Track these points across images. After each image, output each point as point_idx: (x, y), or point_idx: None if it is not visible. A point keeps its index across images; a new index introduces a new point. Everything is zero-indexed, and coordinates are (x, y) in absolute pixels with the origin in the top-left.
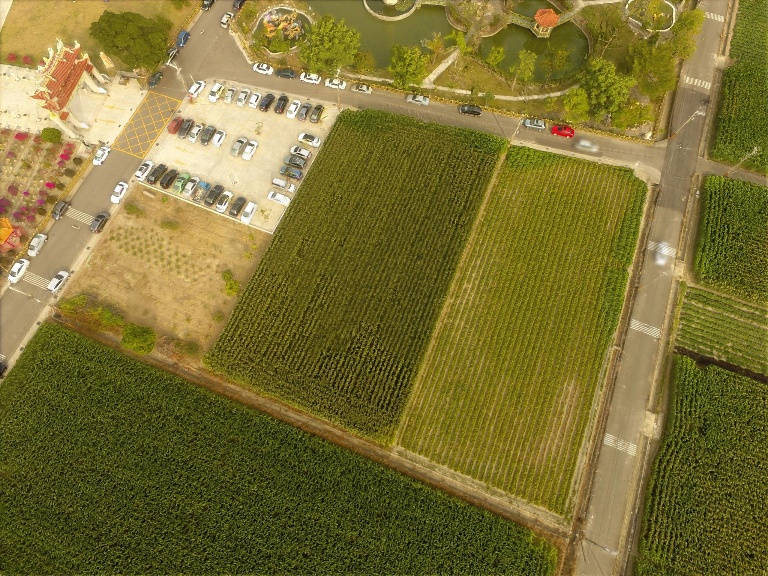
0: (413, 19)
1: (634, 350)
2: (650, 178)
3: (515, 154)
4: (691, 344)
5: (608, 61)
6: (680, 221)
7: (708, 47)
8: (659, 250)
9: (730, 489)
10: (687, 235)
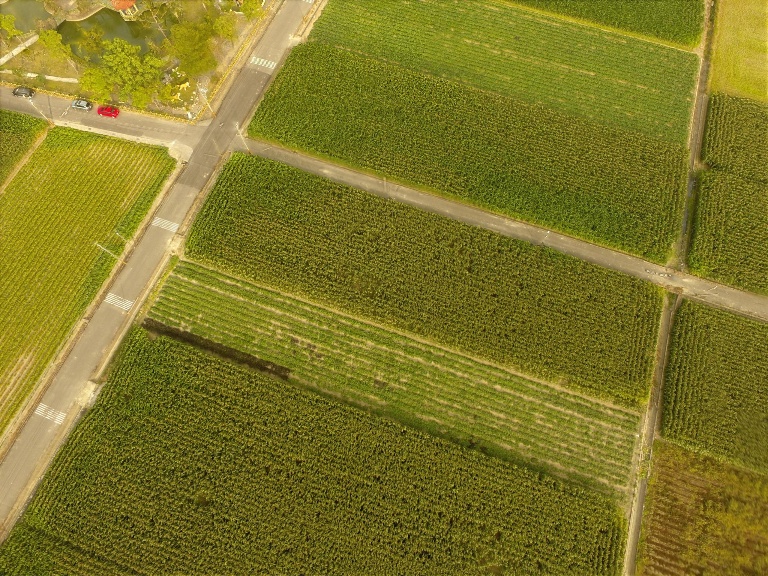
0: (10, 5)
1: (99, 322)
2: (181, 156)
3: (54, 134)
4: (162, 316)
5: (148, 42)
6: (194, 197)
7: (287, 28)
8: (162, 225)
9: (131, 454)
10: (197, 211)
